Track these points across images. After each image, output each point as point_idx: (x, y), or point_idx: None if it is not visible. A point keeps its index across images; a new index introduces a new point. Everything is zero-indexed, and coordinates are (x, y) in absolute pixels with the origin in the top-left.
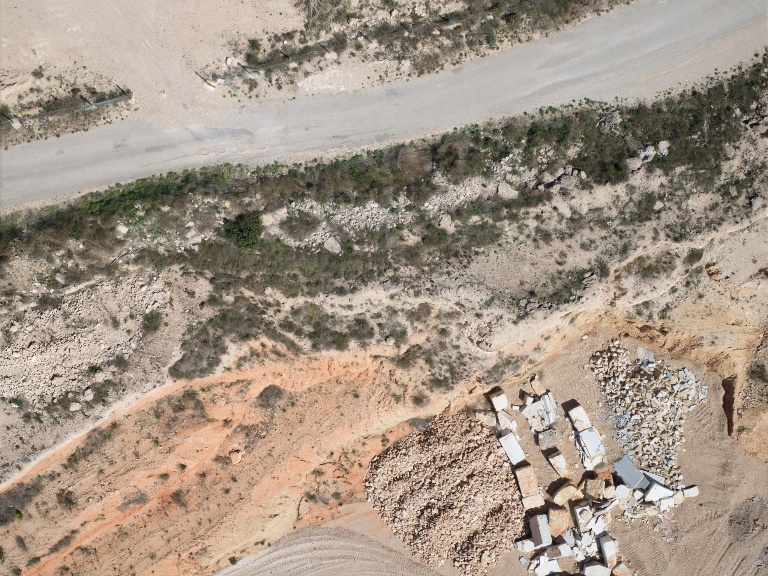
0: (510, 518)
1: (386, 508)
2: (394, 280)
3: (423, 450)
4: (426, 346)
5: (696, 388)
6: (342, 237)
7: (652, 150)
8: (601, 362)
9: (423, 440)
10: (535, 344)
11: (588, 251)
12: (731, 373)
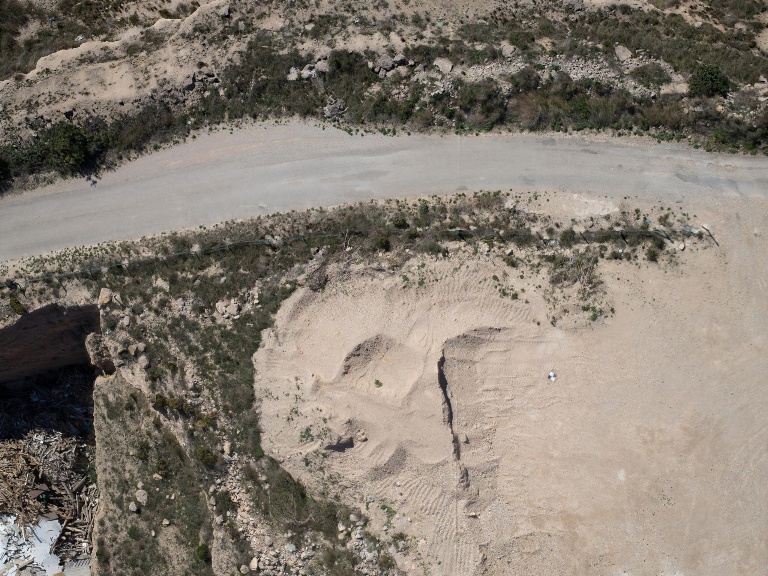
0: None
1: None
2: (571, 10)
3: None
4: None
5: None
6: (612, 58)
7: (304, 74)
8: None
9: None
10: None
11: None
12: None
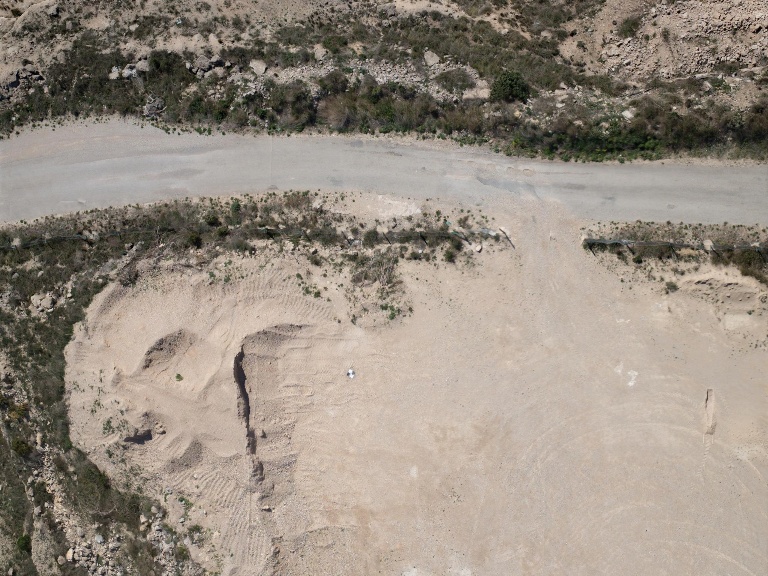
0: None
1: None
2: (384, 15)
3: None
4: None
5: None
6: (420, 63)
7: (125, 73)
8: None
9: None
10: None
11: (205, 2)
12: None
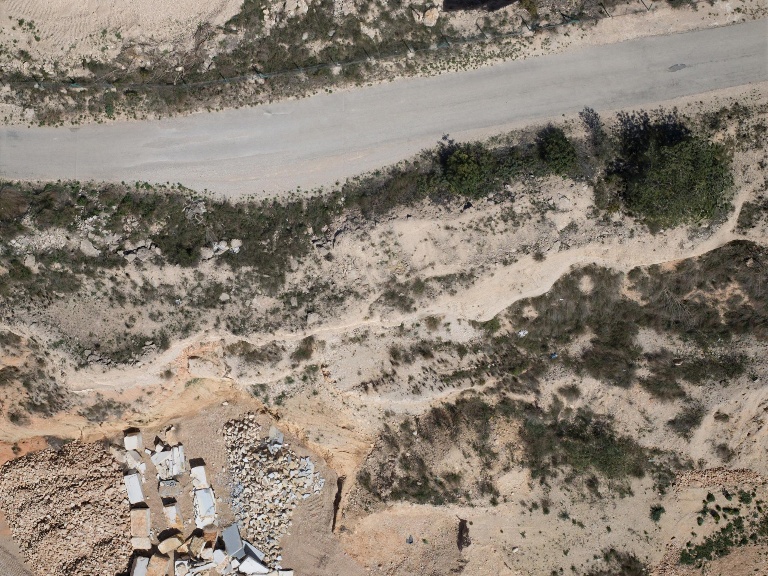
0: (115, 552)
1: (9, 512)
2: None
3: (50, 467)
4: (24, 370)
5: (314, 479)
6: None
7: (225, 245)
8: (232, 430)
9: (54, 458)
10: (137, 395)
11: (154, 321)
12: (342, 473)
